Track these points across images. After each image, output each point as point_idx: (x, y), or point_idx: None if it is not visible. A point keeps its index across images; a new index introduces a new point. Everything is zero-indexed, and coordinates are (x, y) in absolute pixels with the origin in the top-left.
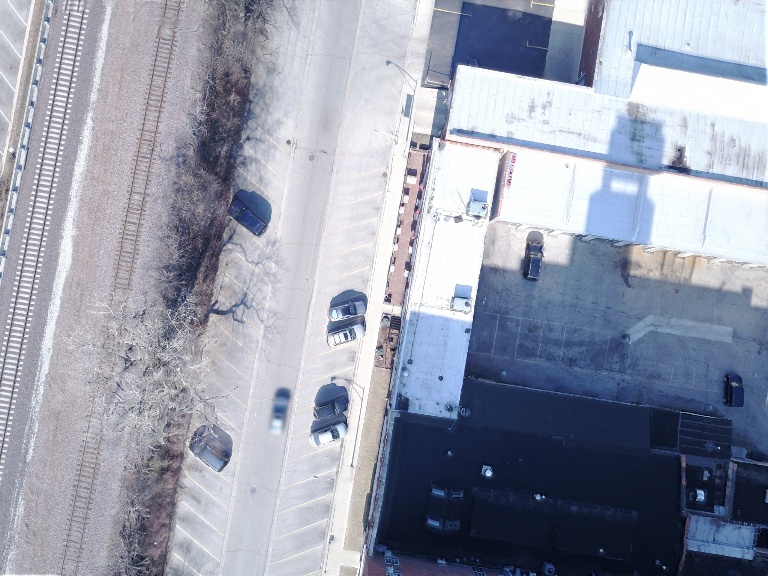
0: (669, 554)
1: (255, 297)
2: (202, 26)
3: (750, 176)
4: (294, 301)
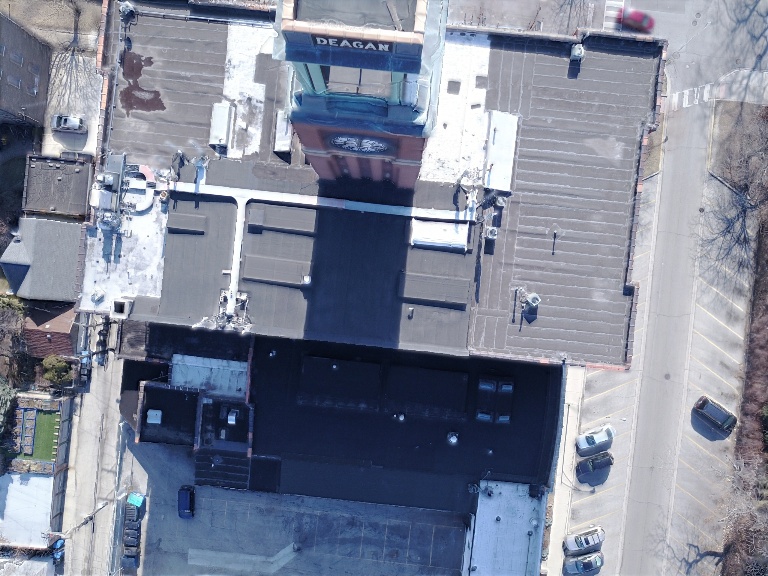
0: (263, 362)
1: (678, 570)
2: None
3: None
4: (637, 568)
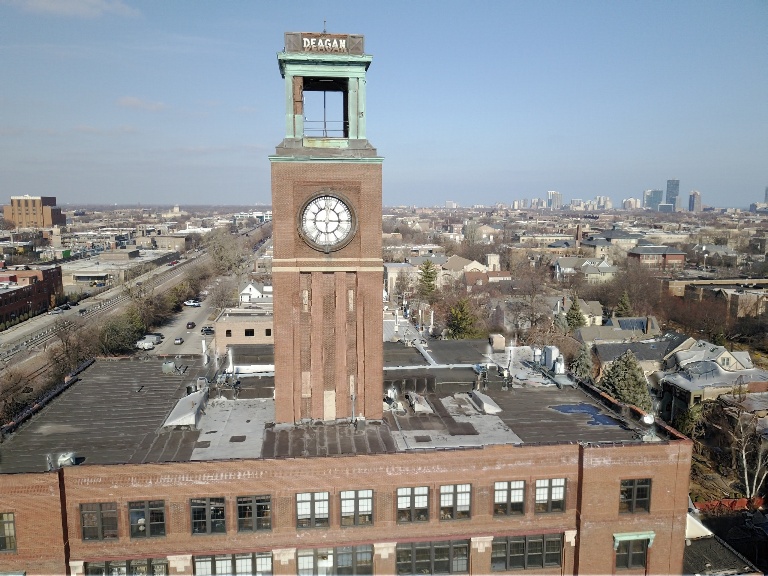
0: None
1: None
2: (48, 376)
3: None
4: None
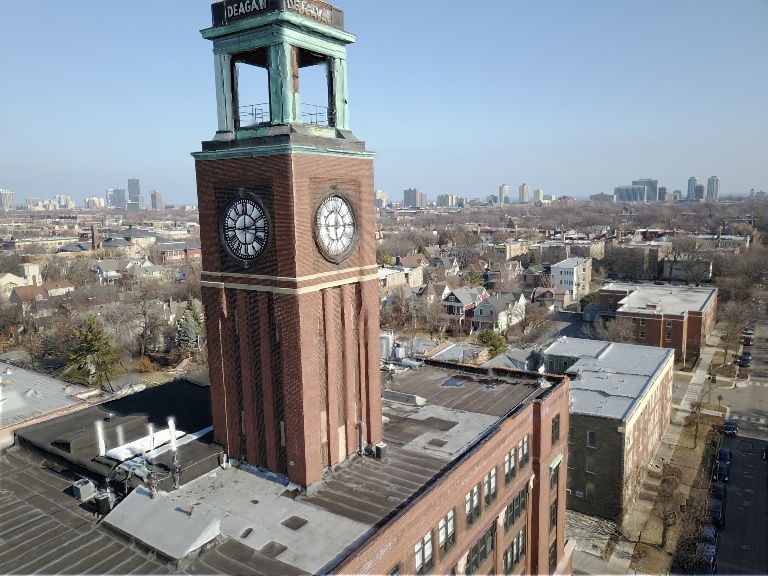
0: None
1: None
2: None
3: (33, 417)
4: None
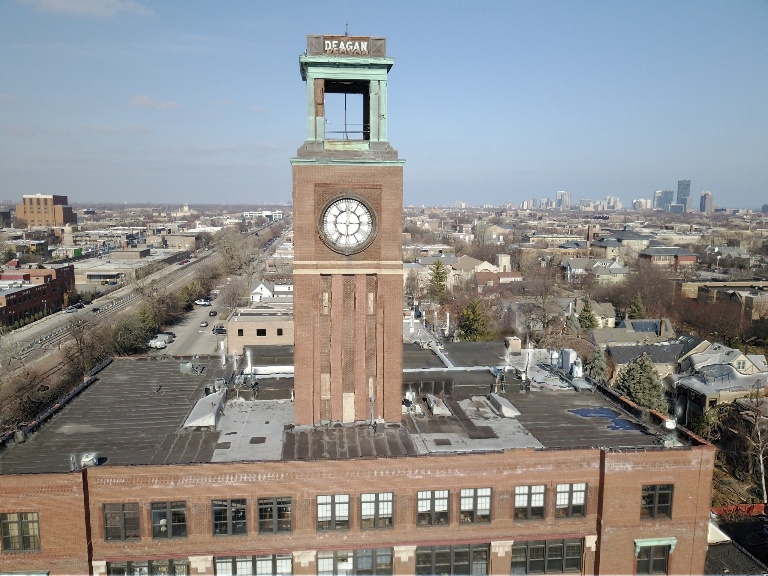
0: None
1: None
2: None
3: None
4: None
